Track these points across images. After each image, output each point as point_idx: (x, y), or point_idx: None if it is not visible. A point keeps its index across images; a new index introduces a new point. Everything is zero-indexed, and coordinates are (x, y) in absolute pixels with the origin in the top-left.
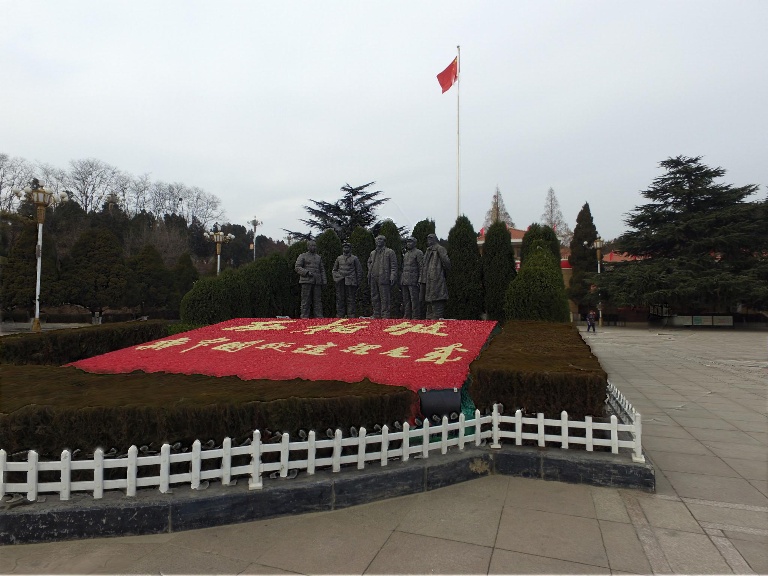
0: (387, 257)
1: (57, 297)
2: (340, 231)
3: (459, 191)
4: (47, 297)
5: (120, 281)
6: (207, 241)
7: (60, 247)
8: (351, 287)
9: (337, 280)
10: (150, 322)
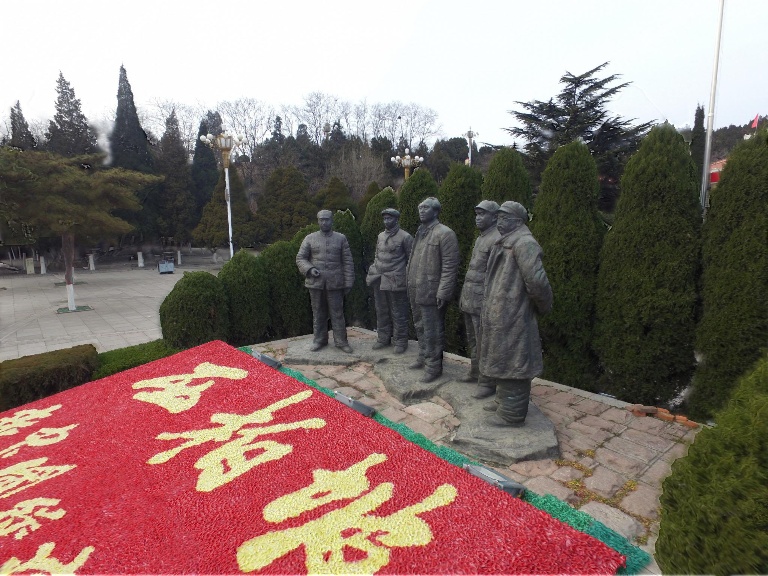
0: (434, 247)
1: (246, 238)
2: None
3: (719, 57)
4: (238, 239)
5: (302, 219)
6: (395, 167)
7: (253, 188)
8: (394, 292)
9: (369, 280)
10: (54, 363)
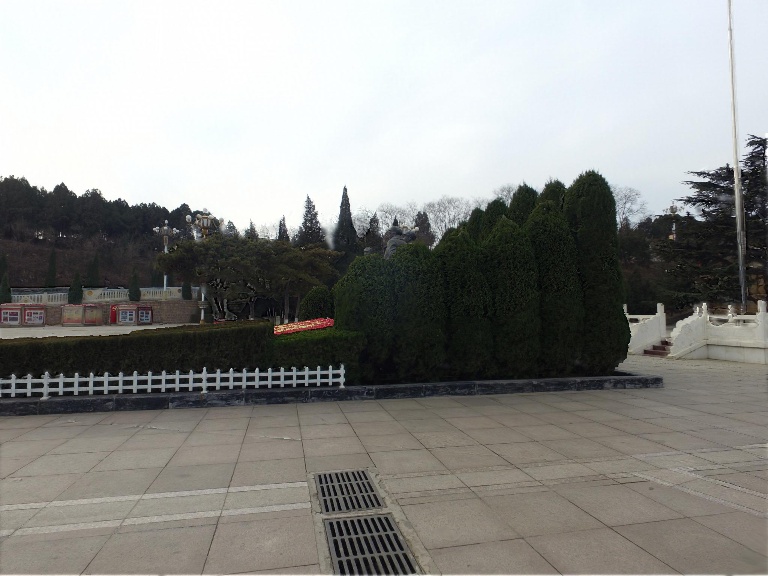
0: None
1: None
2: None
3: (735, 120)
4: None
5: None
6: None
7: None
8: None
9: None
10: None
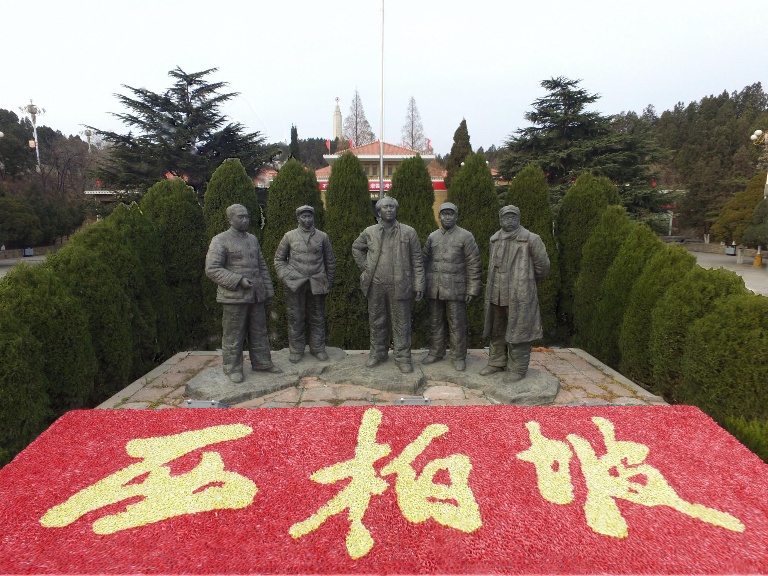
0: (406, 244)
1: None
2: (173, 133)
3: (383, 99)
4: None
5: None
6: None
7: None
8: (320, 296)
9: (294, 285)
10: None
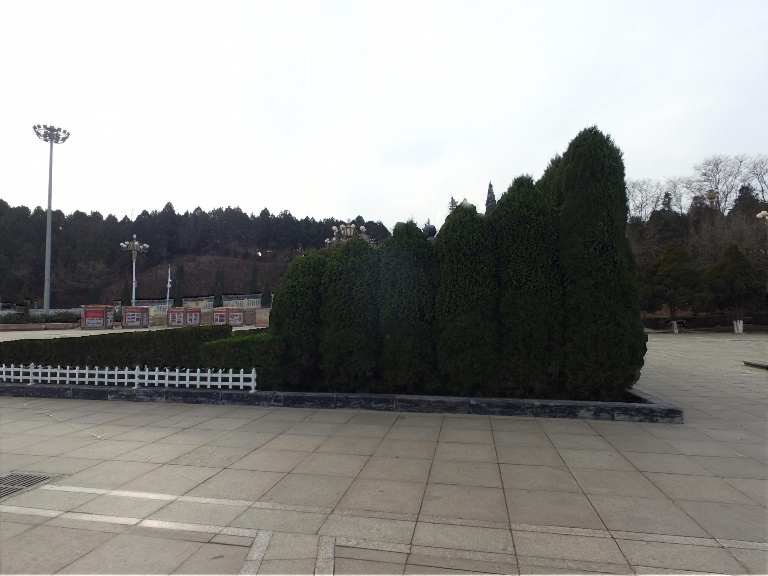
0: None
1: None
2: None
3: None
4: None
5: None
6: (764, 224)
7: None
8: None
9: None
10: None
